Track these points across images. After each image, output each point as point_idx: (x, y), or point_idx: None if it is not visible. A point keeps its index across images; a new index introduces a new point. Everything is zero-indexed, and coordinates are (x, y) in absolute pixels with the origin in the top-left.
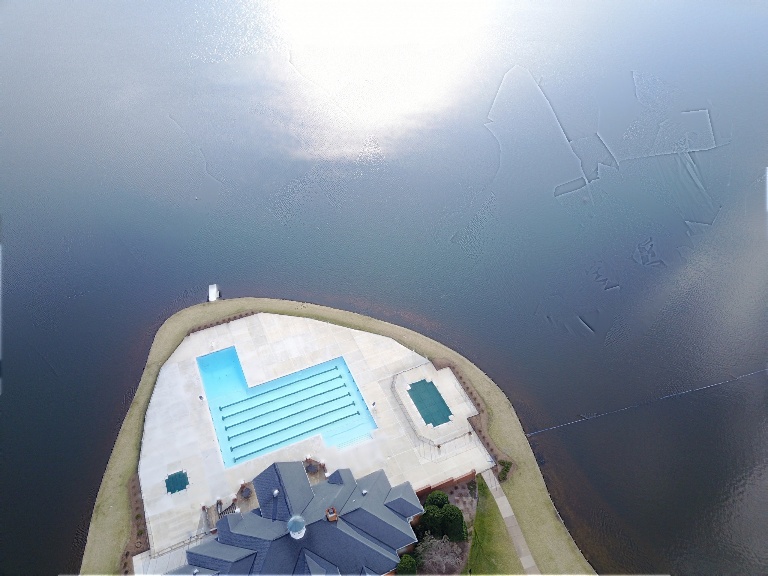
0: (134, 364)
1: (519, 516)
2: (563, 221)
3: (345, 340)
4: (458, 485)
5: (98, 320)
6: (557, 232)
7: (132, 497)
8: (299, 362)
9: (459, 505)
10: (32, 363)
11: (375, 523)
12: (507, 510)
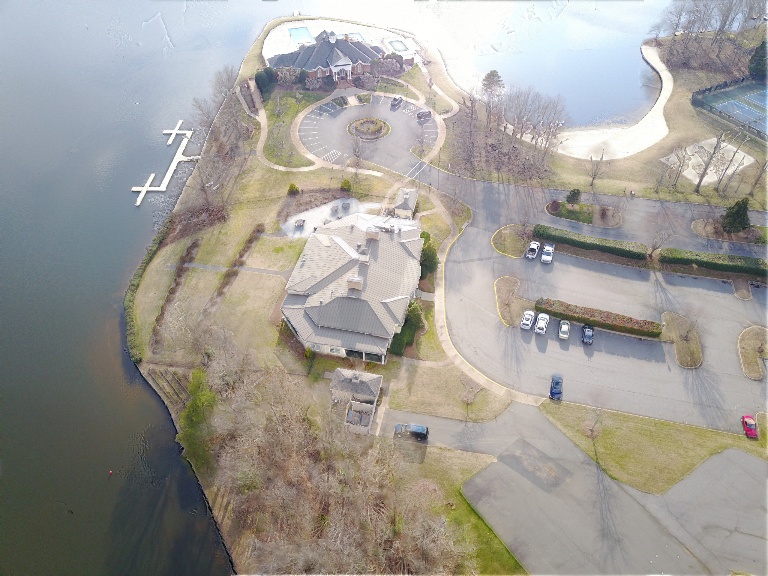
0: (257, 32)
1: (430, 72)
2: (491, 2)
3: (361, 29)
4: (405, 63)
5: (235, 29)
6: (485, 5)
7: (260, 58)
8: (338, 33)
9: (404, 66)
10: (203, 40)
11: (364, 48)
12: (425, 71)
